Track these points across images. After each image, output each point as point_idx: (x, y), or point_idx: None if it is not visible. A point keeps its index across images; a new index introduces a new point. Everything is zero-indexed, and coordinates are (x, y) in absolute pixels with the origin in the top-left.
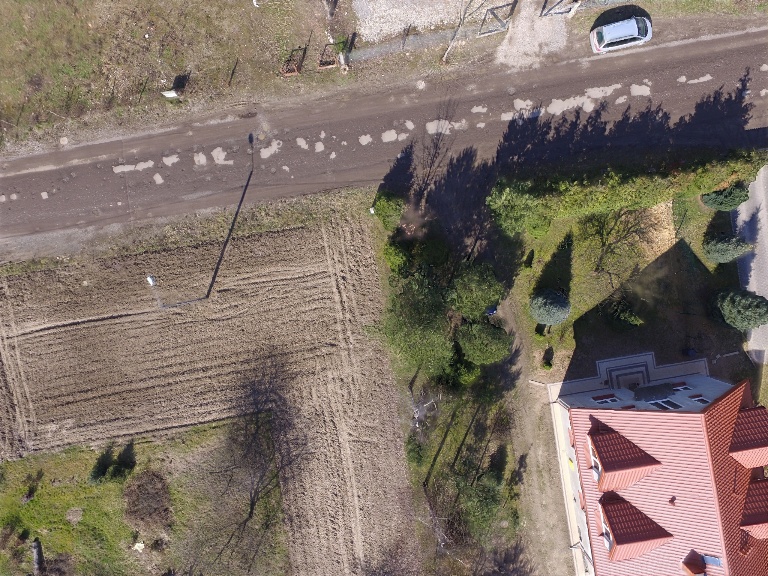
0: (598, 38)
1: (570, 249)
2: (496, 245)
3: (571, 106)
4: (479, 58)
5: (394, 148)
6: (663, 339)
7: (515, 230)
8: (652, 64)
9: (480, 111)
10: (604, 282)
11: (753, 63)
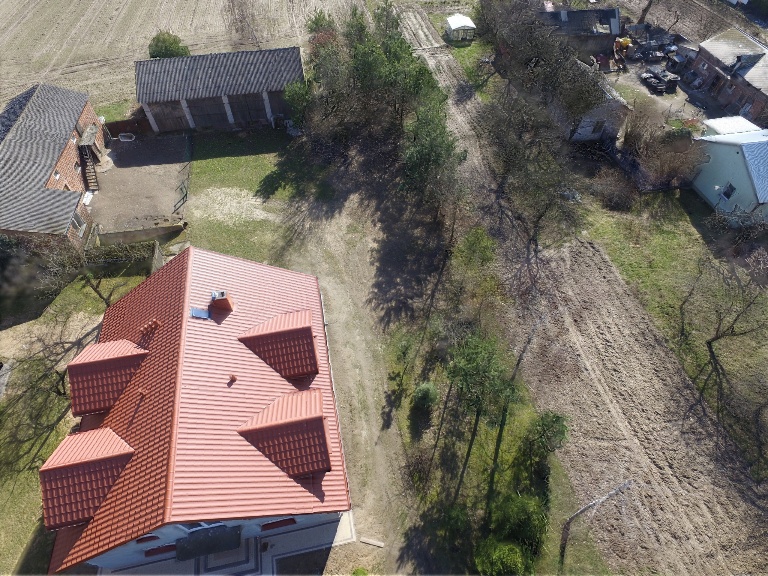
0: None
1: None
2: None
3: None
4: None
5: None
6: None
7: None
8: None
9: None
10: None
11: None
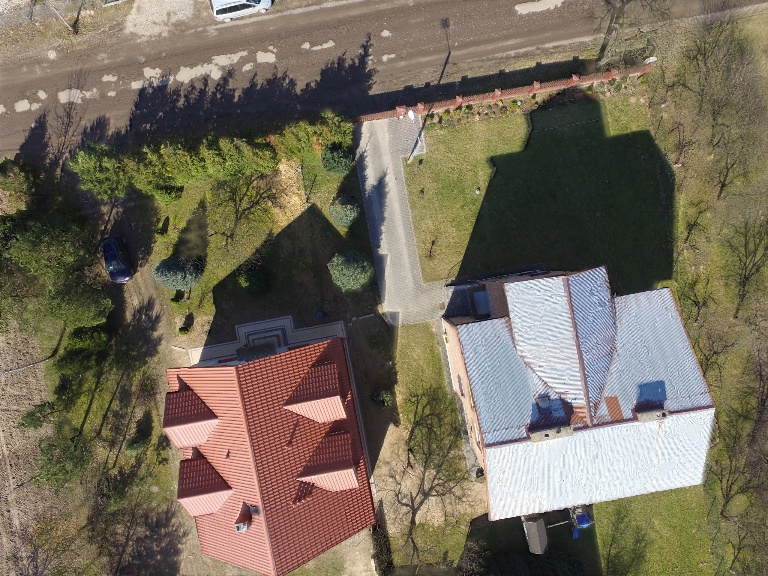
0: (211, 5)
1: (205, 215)
2: (133, 213)
3: (199, 74)
4: (109, 27)
5: (28, 118)
6: (300, 303)
7: (110, 194)
8: (277, 31)
9: (110, 80)
10: (240, 247)
11: (374, 29)
